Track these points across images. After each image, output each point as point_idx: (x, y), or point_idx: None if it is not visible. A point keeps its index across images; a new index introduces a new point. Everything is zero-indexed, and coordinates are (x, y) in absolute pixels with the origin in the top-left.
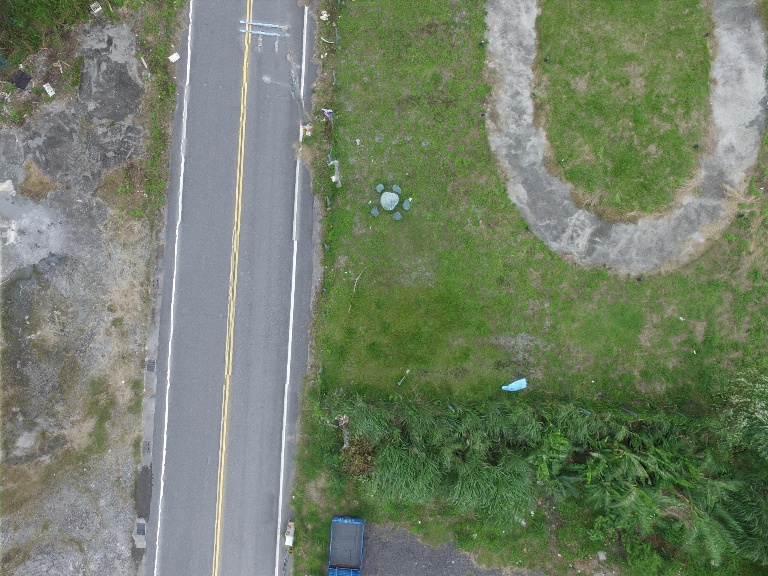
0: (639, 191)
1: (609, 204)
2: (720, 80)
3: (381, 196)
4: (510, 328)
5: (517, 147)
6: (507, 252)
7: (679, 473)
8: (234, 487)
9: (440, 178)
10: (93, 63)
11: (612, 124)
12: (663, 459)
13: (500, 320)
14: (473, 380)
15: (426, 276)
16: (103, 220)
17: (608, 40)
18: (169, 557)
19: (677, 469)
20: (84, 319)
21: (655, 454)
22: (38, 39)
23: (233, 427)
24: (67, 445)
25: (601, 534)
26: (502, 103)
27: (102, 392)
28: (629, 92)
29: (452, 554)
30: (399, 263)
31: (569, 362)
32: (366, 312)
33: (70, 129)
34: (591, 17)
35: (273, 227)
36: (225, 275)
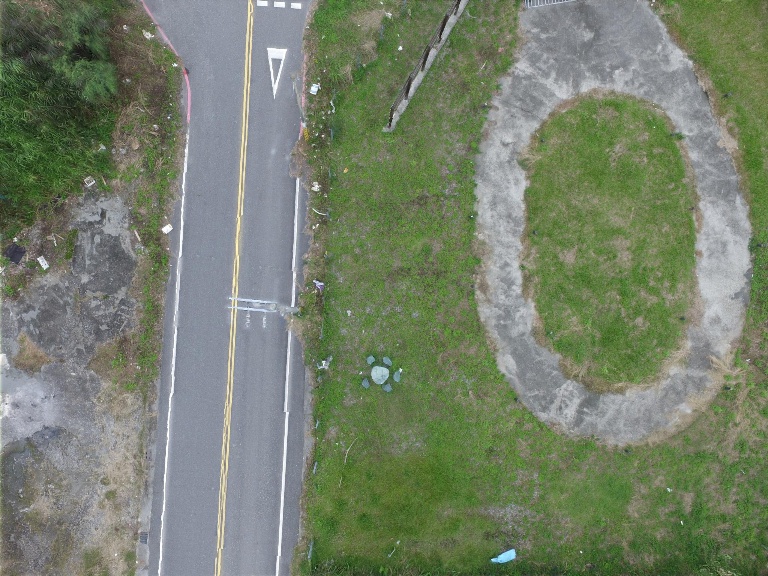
0: (626, 363)
1: (597, 375)
2: (706, 252)
3: (372, 369)
4: (499, 498)
5: (506, 317)
6: (496, 423)
7: None
8: None
9: (430, 349)
10: (87, 236)
11: (600, 296)
12: None
13: (489, 490)
14: (463, 551)
15: (416, 446)
16: (96, 393)
17: (596, 214)
18: None
19: None
20: (77, 492)
21: None
22: (32, 214)
23: None
24: None
25: None
26: (491, 274)
27: (95, 565)
28: (616, 266)
29: None
30: (390, 433)
31: (558, 532)
32: (357, 483)
33: (64, 302)
34: (579, 191)
35: (265, 399)
36: (217, 447)
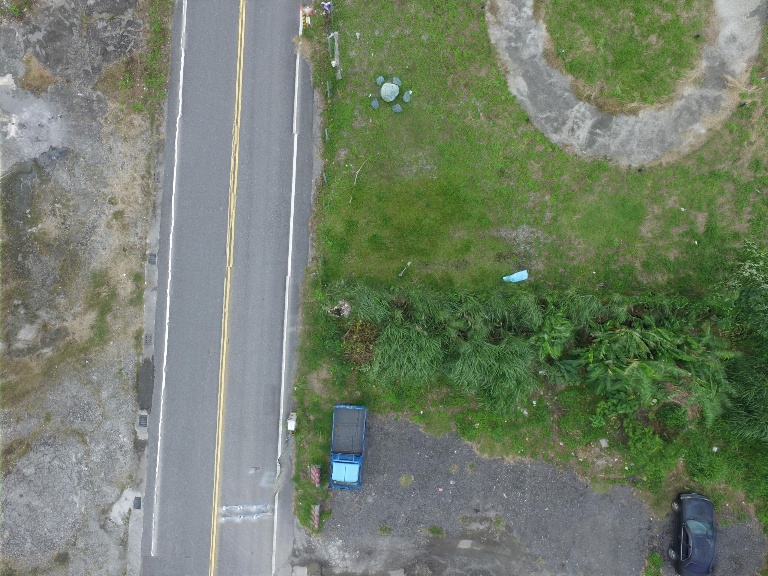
0: (640, 82)
1: (610, 96)
2: None
3: (381, 88)
4: (511, 220)
5: (517, 40)
6: (508, 144)
7: (681, 350)
8: (236, 378)
9: (440, 71)
10: None
11: (612, 15)
12: (665, 338)
13: (501, 212)
14: (474, 272)
15: (427, 169)
16: (103, 114)
17: None
18: (171, 448)
19: (679, 346)
20: (85, 212)
21: (657, 333)
22: None
23: (234, 319)
24: (69, 337)
25: (603, 420)
26: None
27: (103, 285)
28: None
29: (454, 444)
30: (400, 156)
31: (570, 253)
32: (367, 205)
33: (70, 23)
34: None
35: (273, 120)
36: (226, 168)
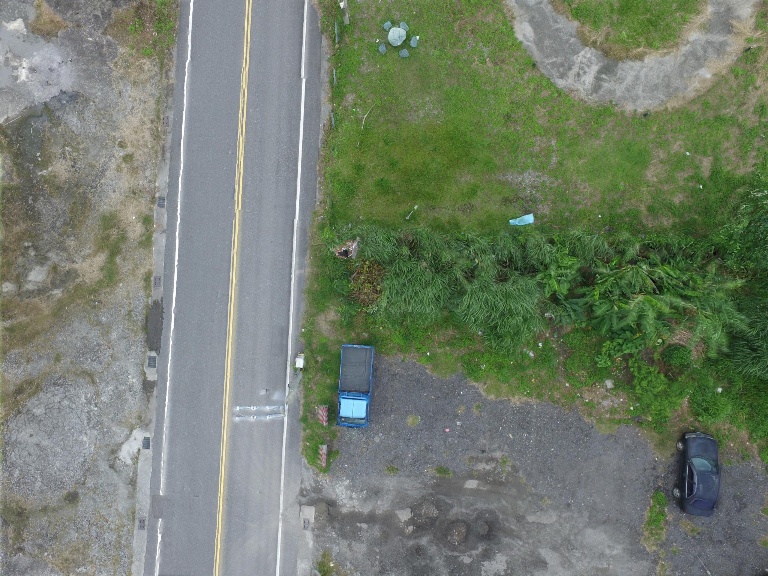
0: (645, 27)
1: (615, 41)
2: None
3: (389, 33)
4: (517, 164)
5: None
6: (514, 89)
7: (687, 285)
8: (244, 320)
9: (447, 17)
10: None
11: None
12: (671, 275)
13: (507, 156)
14: (481, 215)
15: (434, 114)
16: (113, 58)
17: None
18: (180, 389)
19: (685, 282)
20: (95, 155)
21: (663, 270)
22: None
23: (243, 261)
24: (79, 279)
25: (609, 360)
26: None
27: (113, 227)
28: None
29: (461, 385)
30: (407, 101)
31: (576, 197)
32: (374, 149)
33: None
34: None
35: (281, 65)
36: (234, 112)
